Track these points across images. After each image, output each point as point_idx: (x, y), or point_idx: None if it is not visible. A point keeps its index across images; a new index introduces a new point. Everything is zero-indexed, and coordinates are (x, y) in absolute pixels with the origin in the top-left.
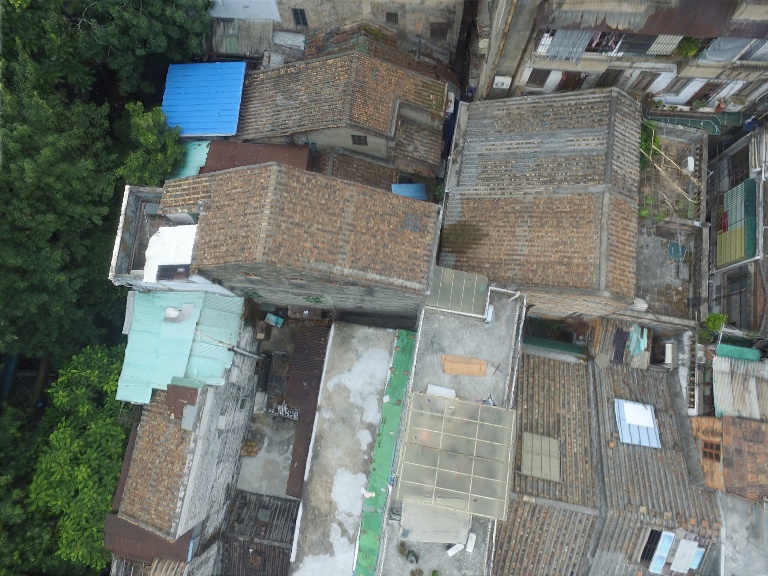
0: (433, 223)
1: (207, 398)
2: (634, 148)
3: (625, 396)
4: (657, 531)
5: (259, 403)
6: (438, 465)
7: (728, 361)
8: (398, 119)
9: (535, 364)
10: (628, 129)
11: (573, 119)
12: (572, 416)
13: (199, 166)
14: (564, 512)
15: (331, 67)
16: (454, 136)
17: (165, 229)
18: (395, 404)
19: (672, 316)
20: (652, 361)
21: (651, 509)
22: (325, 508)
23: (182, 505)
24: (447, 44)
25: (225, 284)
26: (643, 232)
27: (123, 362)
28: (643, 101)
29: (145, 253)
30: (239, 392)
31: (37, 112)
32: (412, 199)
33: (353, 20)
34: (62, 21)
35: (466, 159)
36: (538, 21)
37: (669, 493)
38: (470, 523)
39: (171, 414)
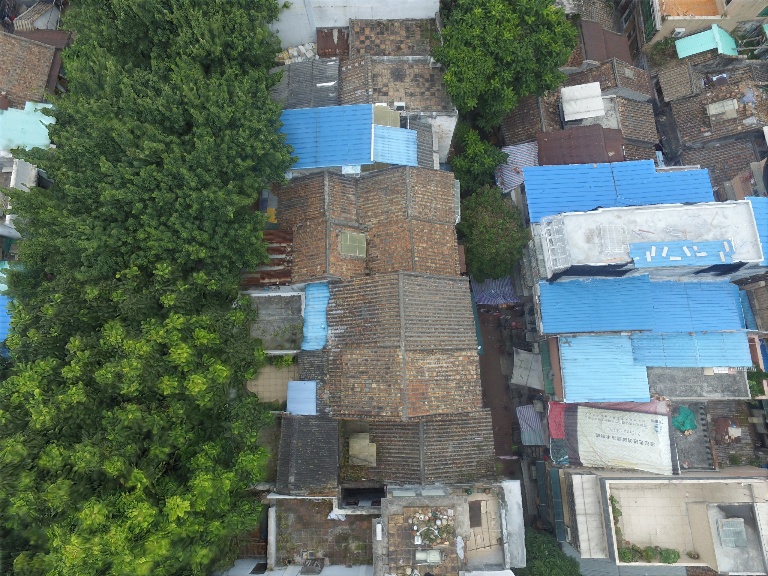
0: None
1: None
2: None
3: None
4: None
5: None
6: None
7: None
8: None
9: None
10: None
11: None
12: None
13: None
14: None
15: None
16: None
17: None
18: None
19: None
20: None
21: None
22: None
23: None
24: None
25: None
26: None
27: None
28: None
29: None
30: None
31: None
32: None
33: None
34: None
35: None
36: None
37: None
38: None
39: (5, 94)
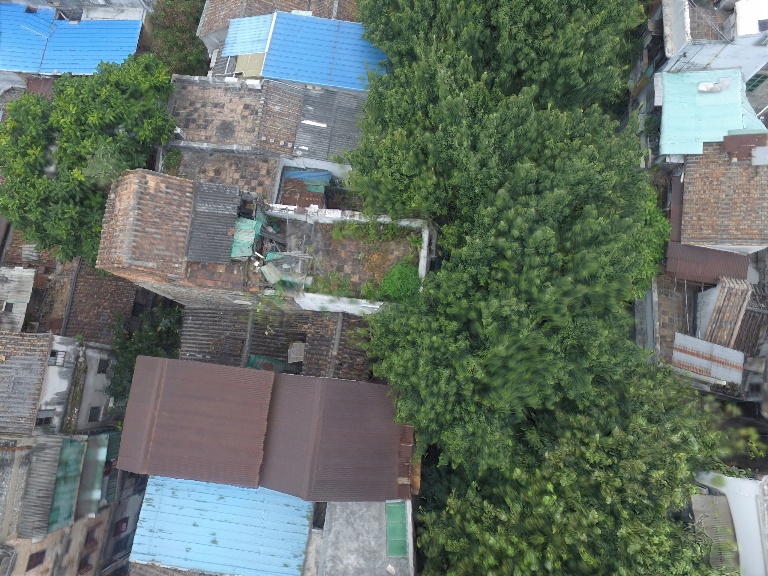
0: None
1: None
2: None
3: None
4: None
5: None
6: None
7: None
8: None
9: None
10: None
11: None
12: None
13: None
14: None
15: None
16: None
17: None
18: None
19: None
20: None
21: None
22: None
23: None
24: None
25: None
26: None
27: (660, 127)
28: None
29: (737, 14)
30: None
31: None
32: None
33: None
34: None
35: None
36: None
37: None
38: None
39: (733, 158)
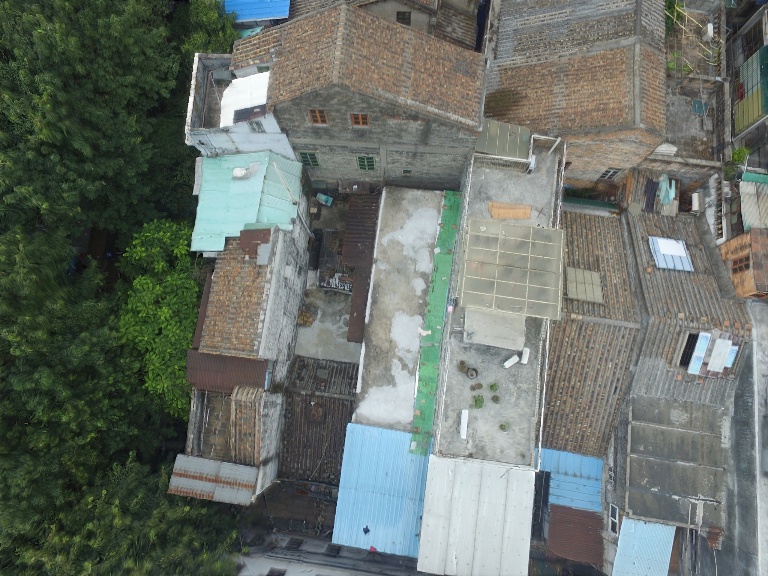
0: (482, 71)
1: (279, 238)
2: (660, 9)
3: (658, 236)
4: (694, 336)
5: (312, 277)
6: (496, 277)
7: (753, 184)
8: None
9: (572, 218)
10: None
11: None
12: (610, 256)
13: None
14: (608, 329)
15: None
16: (489, 17)
17: (238, 80)
18: (446, 253)
19: (699, 159)
20: (680, 209)
21: (688, 316)
22: (386, 346)
23: (263, 327)
24: None
25: (290, 139)
26: (669, 92)
27: None
28: None
29: None
30: (298, 257)
31: None
32: None
33: None
34: None
35: (502, 35)
36: None
37: (703, 304)
38: (524, 337)
39: (245, 256)
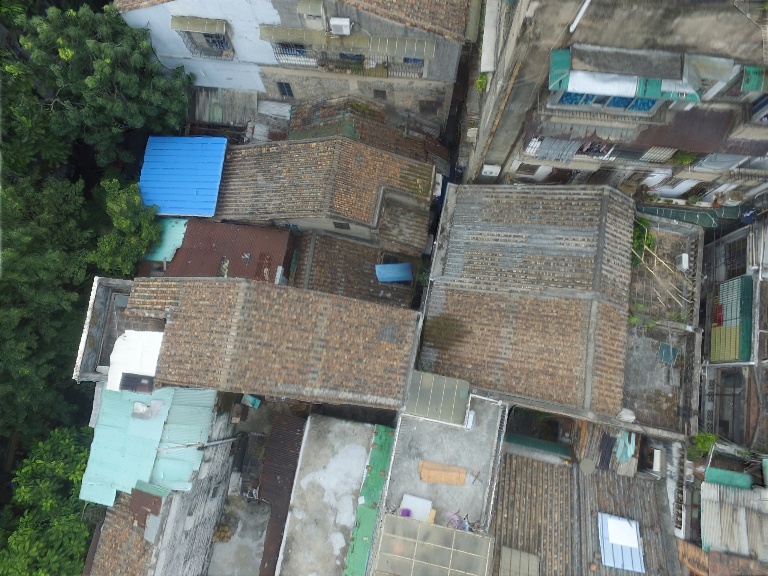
0: (412, 332)
1: (172, 507)
2: (625, 249)
3: (610, 509)
4: None
5: (233, 486)
6: None
7: (717, 489)
8: (382, 206)
9: (518, 466)
10: (620, 229)
11: (563, 215)
12: (554, 527)
13: (176, 246)
14: None
15: (313, 151)
16: (441, 220)
17: (131, 333)
18: (370, 507)
19: (661, 428)
20: (639, 468)
21: None
22: None
23: None
24: (437, 118)
25: None
26: (633, 332)
27: None
28: (637, 194)
29: (110, 357)
30: (211, 482)
31: (2, 205)
32: (390, 307)
33: (340, 95)
34: (34, 102)
35: (452, 246)
36: (526, 125)
37: None
38: None
39: (134, 521)
